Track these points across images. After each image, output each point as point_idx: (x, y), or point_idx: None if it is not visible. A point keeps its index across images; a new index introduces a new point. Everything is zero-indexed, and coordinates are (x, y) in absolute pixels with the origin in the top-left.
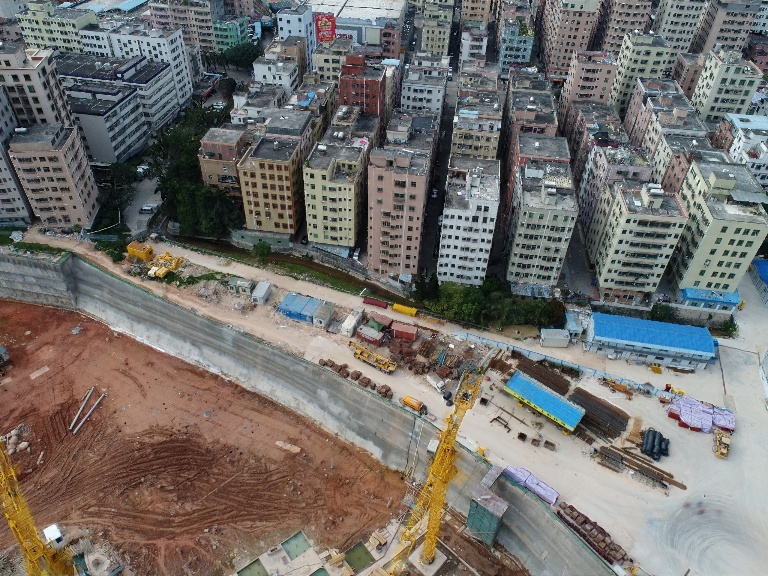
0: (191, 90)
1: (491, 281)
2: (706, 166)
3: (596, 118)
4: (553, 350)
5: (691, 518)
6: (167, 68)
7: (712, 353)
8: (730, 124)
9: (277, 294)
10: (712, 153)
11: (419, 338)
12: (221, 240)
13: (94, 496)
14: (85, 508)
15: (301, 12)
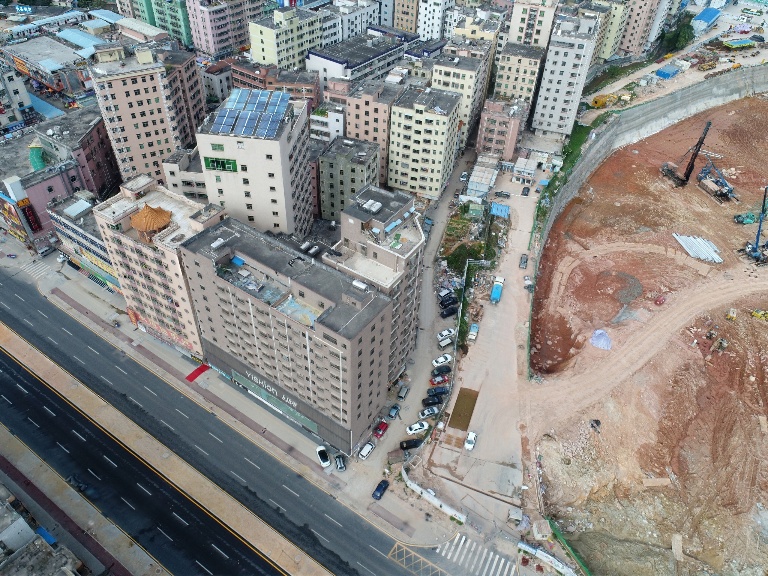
0: None
1: (663, 30)
2: None
3: None
4: None
5: None
6: None
7: None
8: None
9: None
10: None
11: None
12: None
13: (764, 156)
14: None
15: None
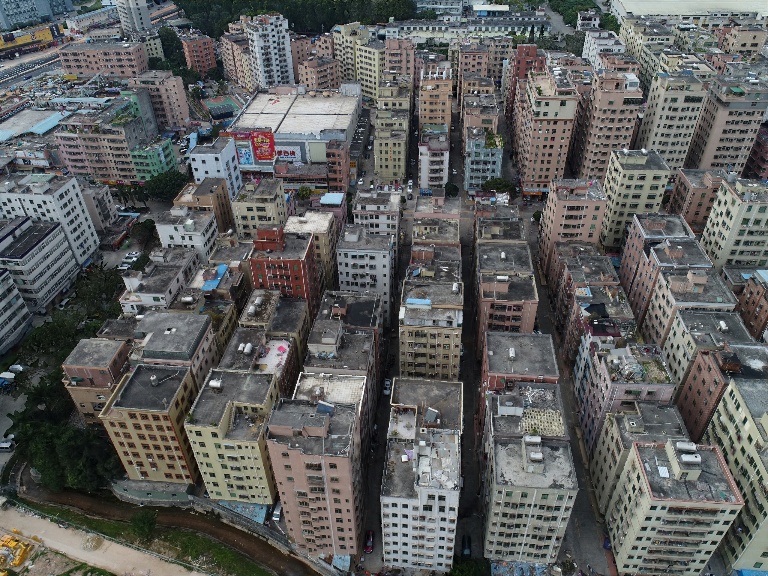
0: (96, 242)
1: (461, 569)
2: (751, 389)
3: (587, 277)
4: None
5: None
6: (56, 229)
7: None
8: (764, 289)
9: None
10: (751, 349)
11: None
12: (100, 489)
13: None
14: None
15: (219, 149)
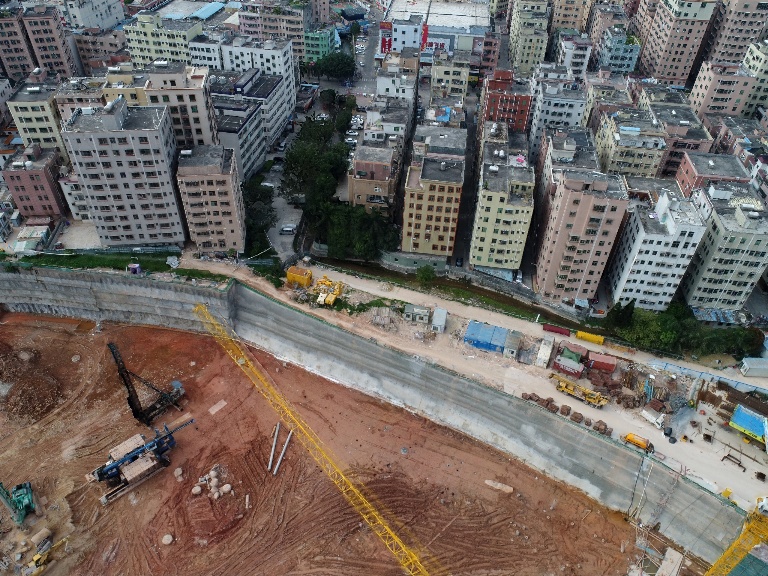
0: (295, 102)
1: (676, 306)
2: None
3: (742, 132)
4: (757, 380)
5: None
6: (281, 81)
7: None
8: None
9: (453, 321)
10: None
11: (616, 368)
12: (369, 262)
13: (316, 544)
14: (310, 557)
15: (416, 22)
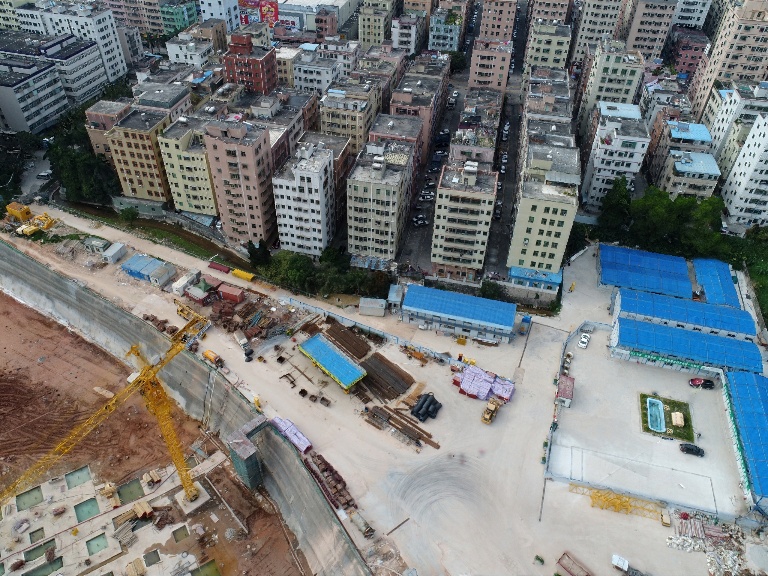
0: (125, 69)
1: (329, 252)
2: (538, 148)
3: (479, 103)
4: (369, 318)
5: (431, 474)
6: (93, 46)
7: (510, 327)
8: (598, 111)
9: (131, 255)
10: (561, 137)
11: (245, 300)
12: (105, 206)
13: None
14: None
15: None
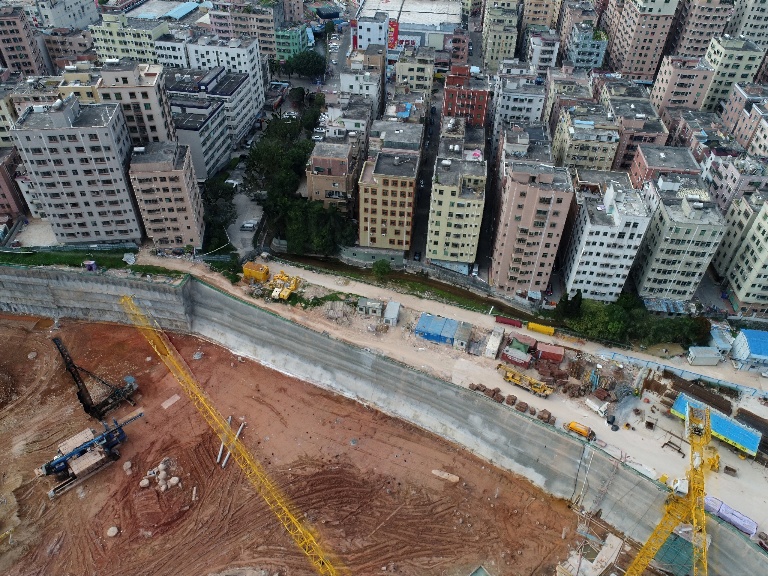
0: (263, 100)
1: (627, 297)
2: None
3: (700, 125)
4: (703, 368)
5: None
6: (247, 79)
7: None
8: None
9: (406, 314)
10: None
11: (564, 359)
12: (329, 257)
13: (260, 534)
14: (254, 547)
15: (381, 20)
